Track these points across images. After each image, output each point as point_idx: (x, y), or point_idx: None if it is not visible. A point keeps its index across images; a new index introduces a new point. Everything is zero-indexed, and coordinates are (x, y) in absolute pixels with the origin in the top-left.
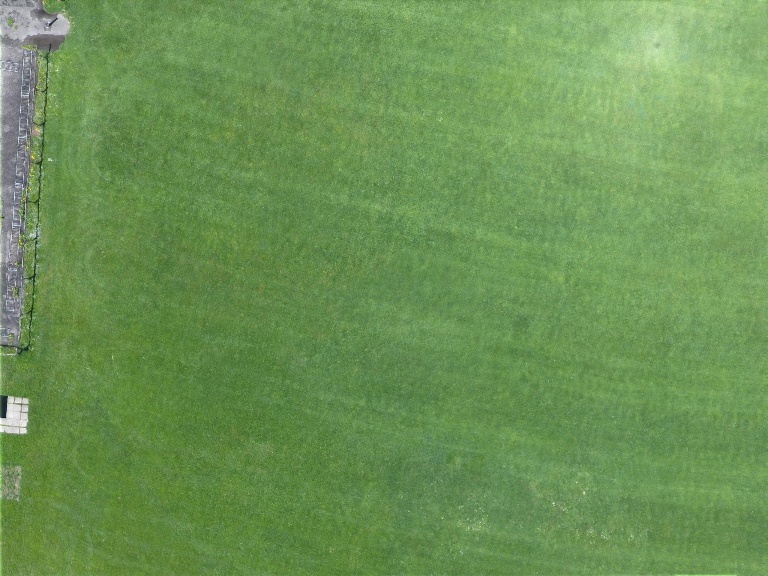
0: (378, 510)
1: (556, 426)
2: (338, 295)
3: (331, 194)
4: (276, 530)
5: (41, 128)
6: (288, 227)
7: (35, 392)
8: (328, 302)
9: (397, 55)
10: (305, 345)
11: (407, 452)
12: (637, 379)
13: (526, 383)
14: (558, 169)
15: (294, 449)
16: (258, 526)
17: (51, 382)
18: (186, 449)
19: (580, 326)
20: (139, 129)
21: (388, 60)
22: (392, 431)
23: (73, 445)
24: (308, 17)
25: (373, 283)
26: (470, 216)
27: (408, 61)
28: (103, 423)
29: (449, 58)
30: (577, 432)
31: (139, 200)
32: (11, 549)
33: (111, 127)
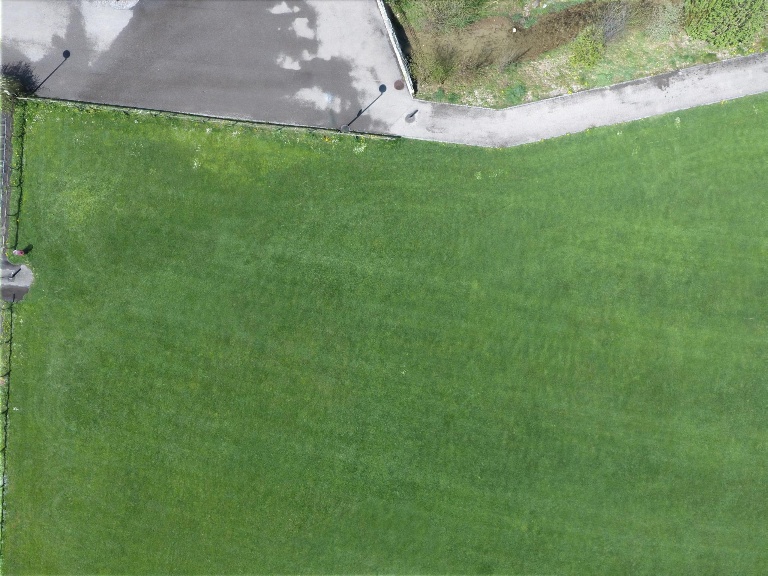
0: None
1: None
2: (304, 543)
3: (296, 444)
4: None
5: (6, 378)
6: (254, 476)
7: None
8: (294, 549)
9: (360, 309)
10: None
11: None
12: None
13: None
14: (520, 422)
15: None
16: None
17: None
18: None
19: (543, 573)
20: (104, 380)
21: (351, 314)
22: None
23: None
24: (271, 270)
25: (338, 531)
26: (434, 467)
27: (371, 315)
28: None
29: (411, 312)
30: None
31: (105, 449)
32: None
33: (76, 378)
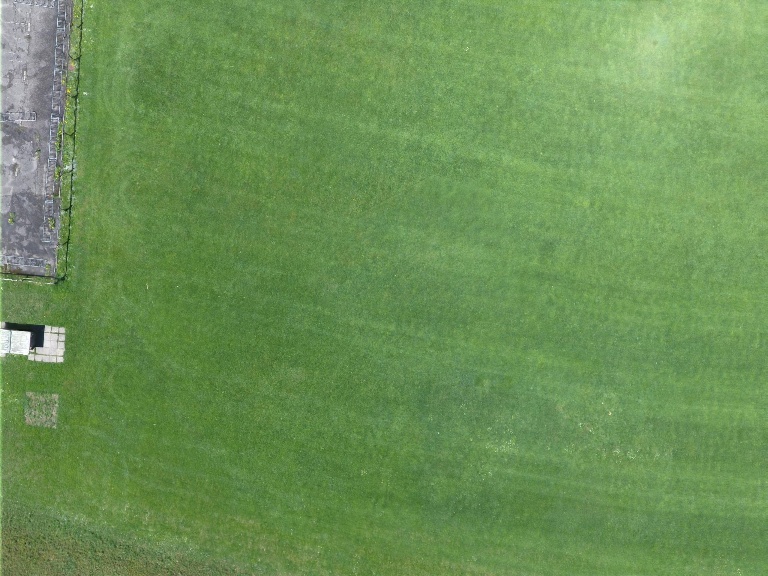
0: (408, 433)
1: (582, 348)
2: (368, 222)
3: (360, 123)
4: (308, 454)
5: (76, 63)
6: (318, 156)
7: (72, 321)
8: (358, 229)
9: None
10: (336, 272)
11: (436, 376)
12: (661, 301)
13: (552, 306)
14: (582, 96)
15: (326, 374)
16: (291, 450)
17: (87, 311)
18: (220, 376)
19: (605, 250)
20: (172, 62)
21: None
22: (422, 355)
23: (109, 373)
24: None
25: (402, 210)
26: (496, 143)
27: None
28: (138, 351)
29: None
30: (603, 354)
31: (173, 132)
32: (49, 476)
33: (145, 60)
